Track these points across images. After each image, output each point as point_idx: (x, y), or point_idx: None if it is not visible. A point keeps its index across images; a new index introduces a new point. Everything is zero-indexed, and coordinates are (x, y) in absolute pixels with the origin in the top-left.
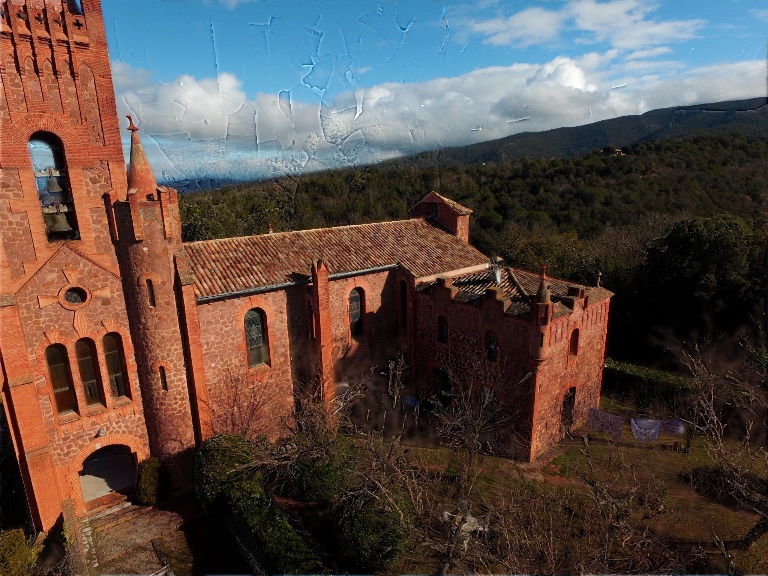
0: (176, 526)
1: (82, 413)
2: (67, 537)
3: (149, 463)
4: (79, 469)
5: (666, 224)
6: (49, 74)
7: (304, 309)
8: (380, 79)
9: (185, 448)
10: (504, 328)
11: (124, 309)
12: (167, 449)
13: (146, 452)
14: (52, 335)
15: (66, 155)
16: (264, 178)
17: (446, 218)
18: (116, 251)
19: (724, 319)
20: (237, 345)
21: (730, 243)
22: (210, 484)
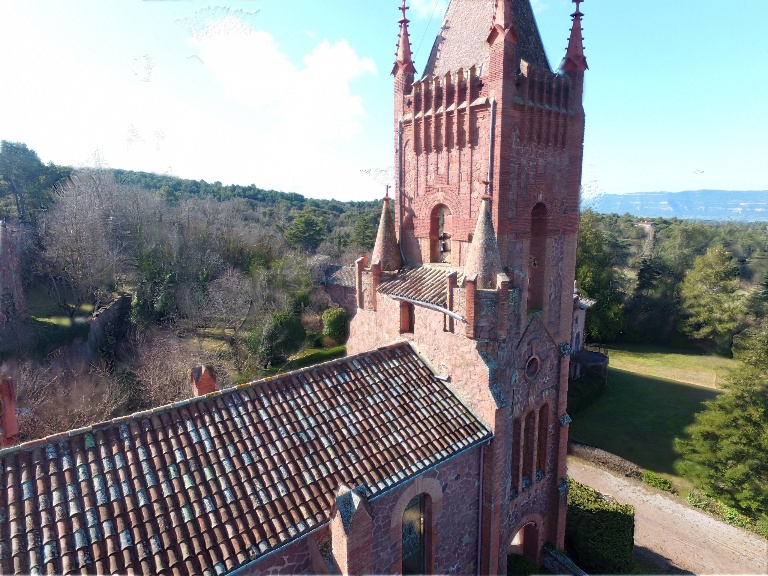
0: None
1: None
2: None
3: None
4: None
5: None
6: None
7: None
8: (197, 192)
9: None
10: None
11: None
12: None
13: None
14: None
15: None
16: None
17: None
18: None
19: None
20: None
21: None
22: None
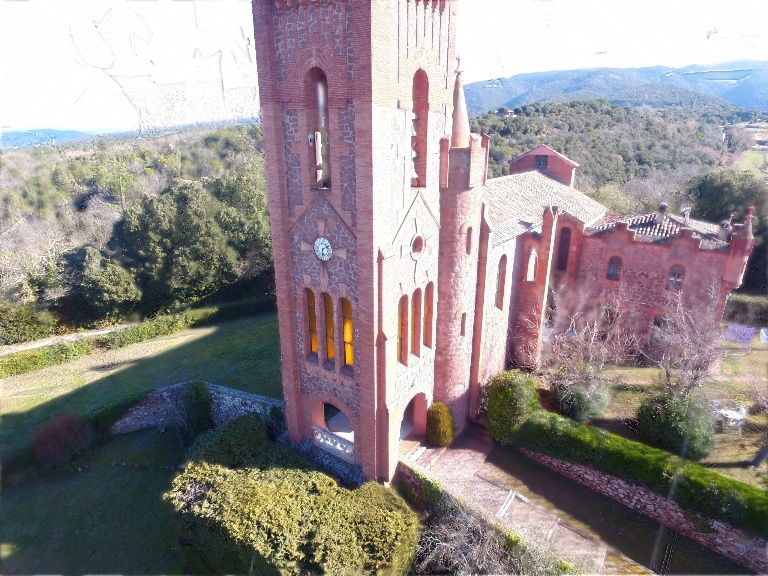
0: (483, 459)
1: (408, 364)
2: (429, 480)
3: (440, 408)
4: (401, 419)
5: (679, 176)
6: (429, 7)
7: (521, 255)
8: None
9: (465, 390)
10: (696, 261)
11: (437, 258)
12: (453, 393)
13: (431, 398)
14: (404, 286)
15: (429, 97)
16: (228, 130)
17: (559, 170)
18: (440, 199)
19: (759, 251)
20: (492, 290)
21: (765, 190)
22: (523, 415)
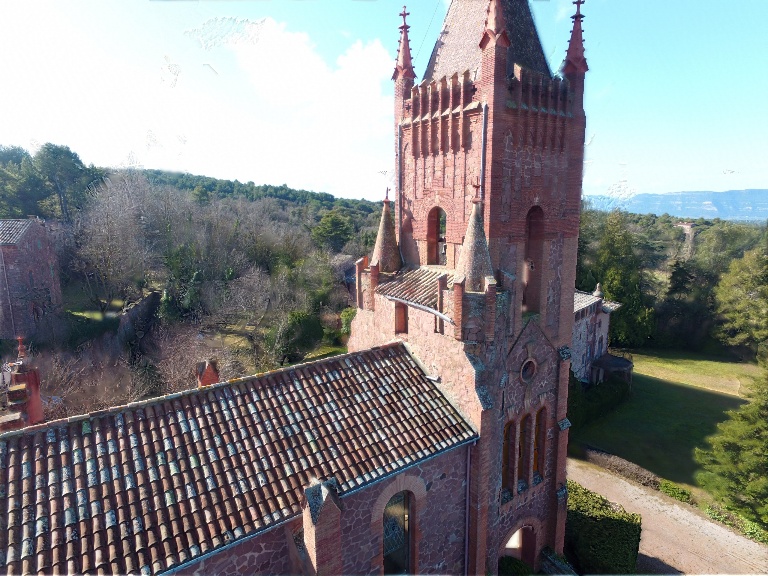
0: None
1: None
2: None
3: None
4: None
5: None
6: None
7: None
8: (212, 194)
9: None
10: None
11: None
12: None
13: None
14: None
15: None
16: None
17: None
18: None
19: None
20: None
21: None
22: None
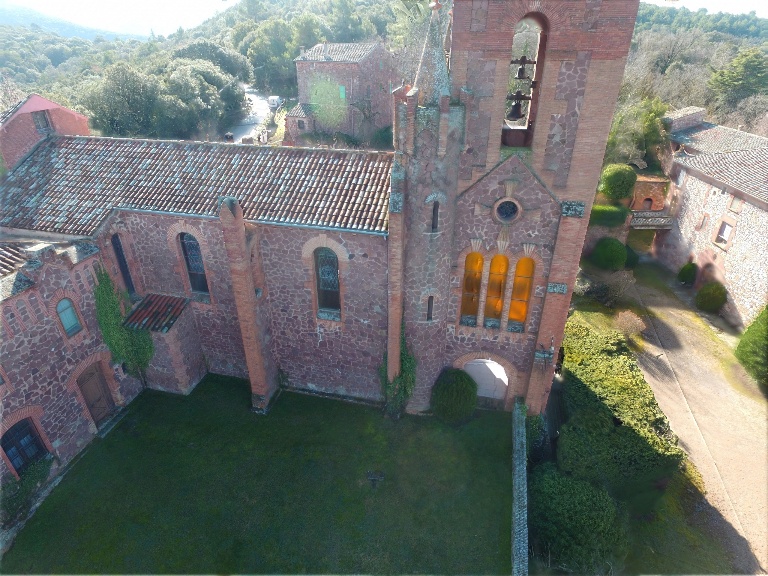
0: None
1: None
2: None
3: None
4: None
5: None
6: None
7: None
8: (410, 14)
9: None
10: None
11: None
12: None
13: None
14: None
15: None
16: None
17: (72, 129)
18: None
19: None
20: None
21: None
22: None
